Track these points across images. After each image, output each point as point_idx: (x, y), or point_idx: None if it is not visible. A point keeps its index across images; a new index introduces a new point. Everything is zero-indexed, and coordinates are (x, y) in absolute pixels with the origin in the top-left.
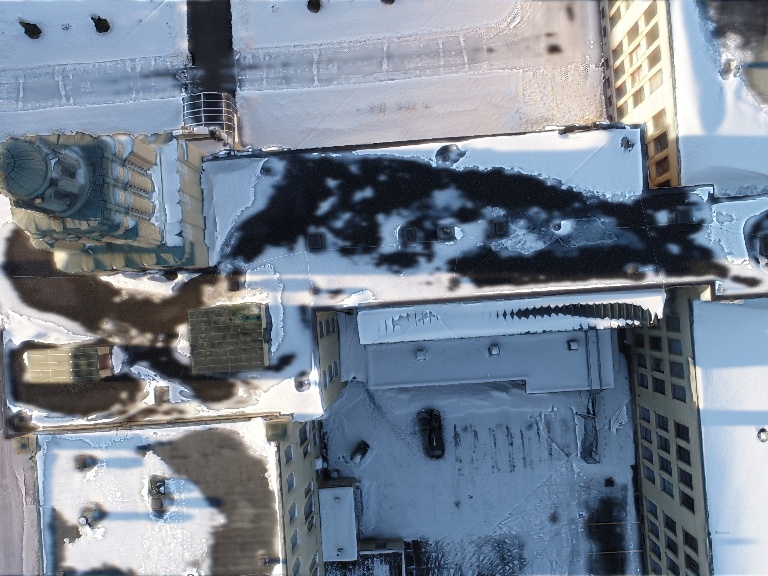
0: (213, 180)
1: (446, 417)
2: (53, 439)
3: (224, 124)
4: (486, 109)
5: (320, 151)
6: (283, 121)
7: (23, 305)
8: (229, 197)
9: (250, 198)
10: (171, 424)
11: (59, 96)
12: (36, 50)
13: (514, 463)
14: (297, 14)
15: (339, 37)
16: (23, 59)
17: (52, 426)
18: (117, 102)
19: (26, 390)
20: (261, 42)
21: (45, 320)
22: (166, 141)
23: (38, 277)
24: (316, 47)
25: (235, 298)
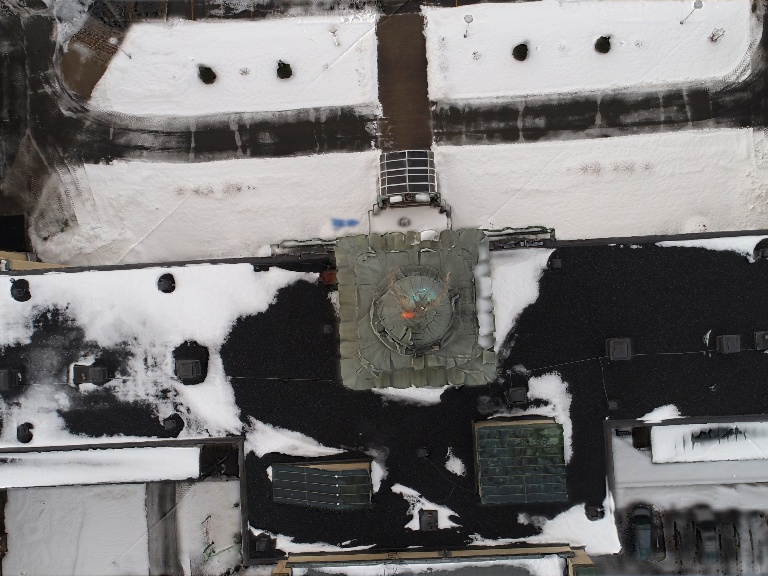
0: (493, 273)
1: (665, 514)
2: (309, 572)
3: (429, 185)
4: (712, 171)
5: (618, 241)
6: (484, 180)
7: (267, 411)
8: (510, 292)
9: (534, 294)
10: (449, 559)
11: (234, 147)
12: (210, 96)
13: (742, 567)
14: (501, 62)
15: (547, 88)
16: (196, 106)
17: (300, 553)
18: (299, 155)
19: (269, 510)
20: (460, 92)
21: (292, 429)
22: (477, 239)
23: (285, 379)
24: (521, 99)
25: (515, 409)
